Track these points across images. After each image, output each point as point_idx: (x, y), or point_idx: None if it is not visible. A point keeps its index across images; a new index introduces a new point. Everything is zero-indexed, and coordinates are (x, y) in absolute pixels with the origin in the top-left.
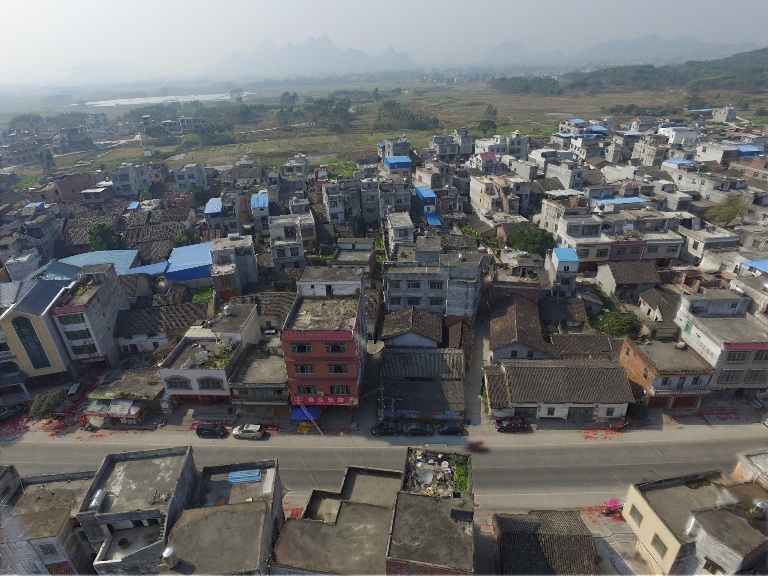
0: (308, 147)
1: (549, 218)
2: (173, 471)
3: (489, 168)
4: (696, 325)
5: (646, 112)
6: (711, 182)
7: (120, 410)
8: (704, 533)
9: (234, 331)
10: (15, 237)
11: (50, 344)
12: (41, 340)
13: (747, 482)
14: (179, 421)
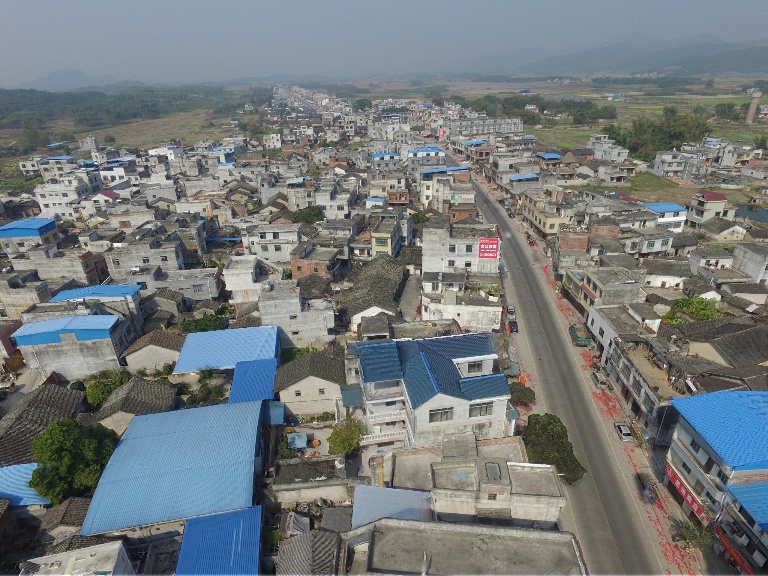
0: None
1: (299, 200)
2: (599, 273)
3: None
4: (457, 193)
5: (4, 153)
6: (284, 166)
7: (514, 355)
8: None
9: None
10: None
11: None
12: None
13: None
14: None
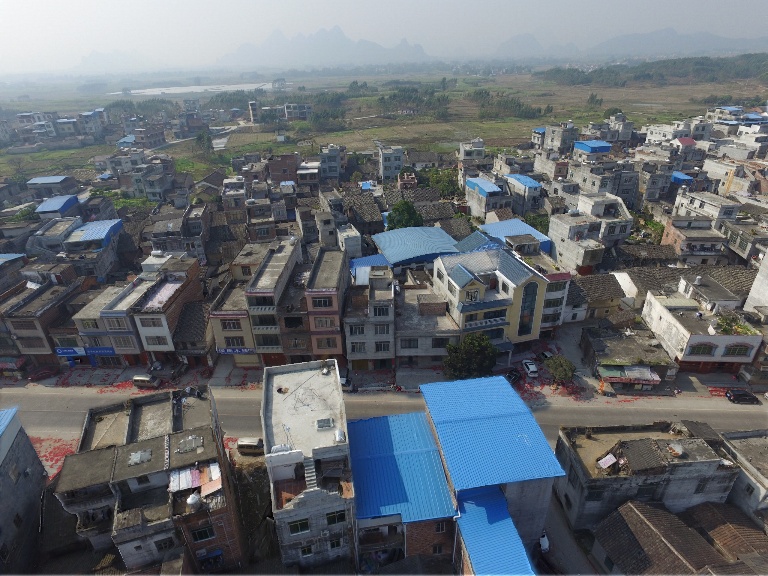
0: (432, 134)
1: None
2: None
3: (687, 153)
4: None
5: (744, 103)
6: None
7: (641, 376)
8: None
9: (734, 299)
10: (326, 212)
11: (540, 311)
12: (535, 307)
13: None
14: (692, 388)
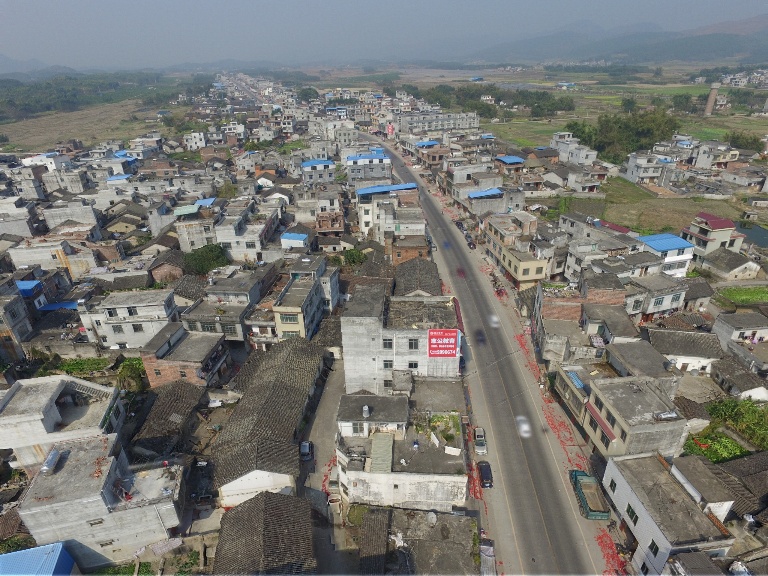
0: None
1: (194, 236)
2: (613, 389)
3: None
4: (403, 223)
5: None
6: (190, 180)
7: (491, 570)
8: (547, 249)
9: None
10: None
11: None
12: None
13: None
14: (474, 514)
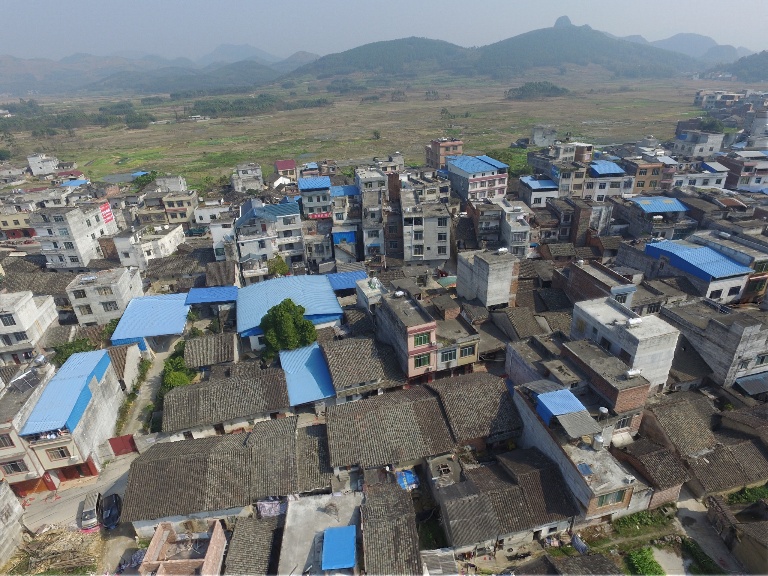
0: None
1: None
2: None
3: None
4: None
5: None
6: None
7: None
8: None
9: None
10: None
11: None
12: None
13: (2, 207)
14: None
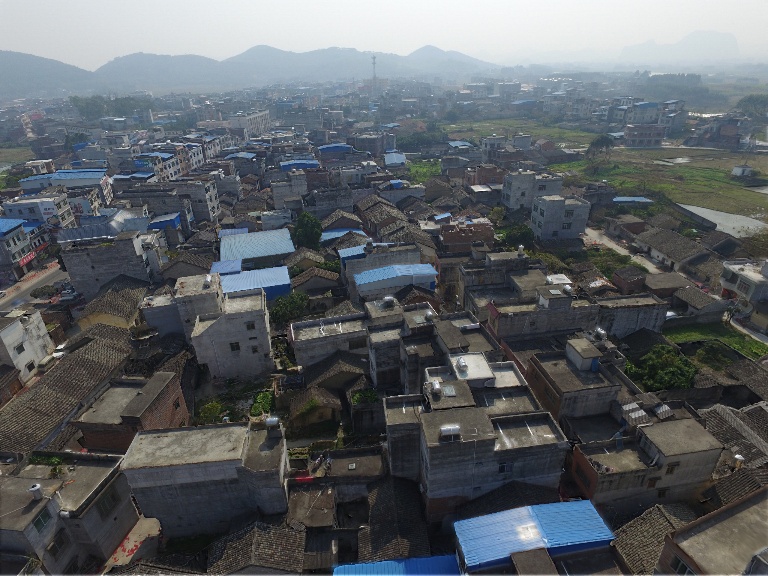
0: None
1: None
2: None
3: None
4: None
5: None
6: None
7: None
8: None
9: None
10: None
11: None
12: None
13: None
14: None
